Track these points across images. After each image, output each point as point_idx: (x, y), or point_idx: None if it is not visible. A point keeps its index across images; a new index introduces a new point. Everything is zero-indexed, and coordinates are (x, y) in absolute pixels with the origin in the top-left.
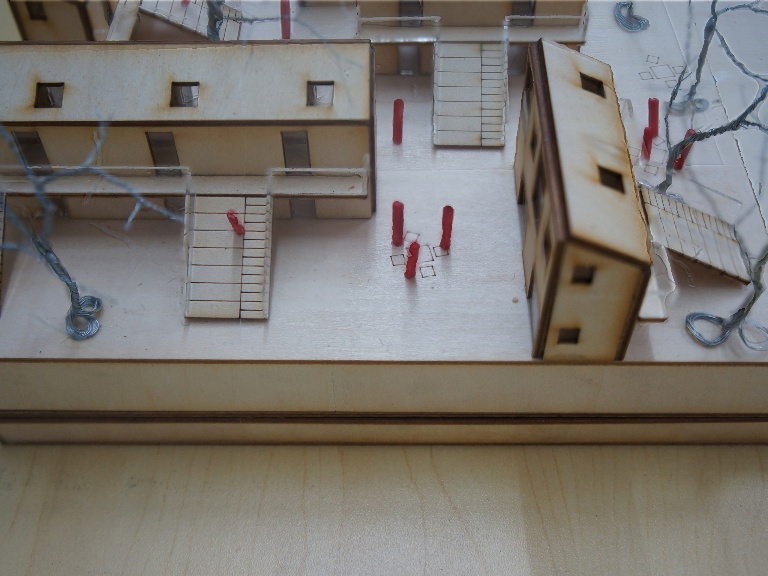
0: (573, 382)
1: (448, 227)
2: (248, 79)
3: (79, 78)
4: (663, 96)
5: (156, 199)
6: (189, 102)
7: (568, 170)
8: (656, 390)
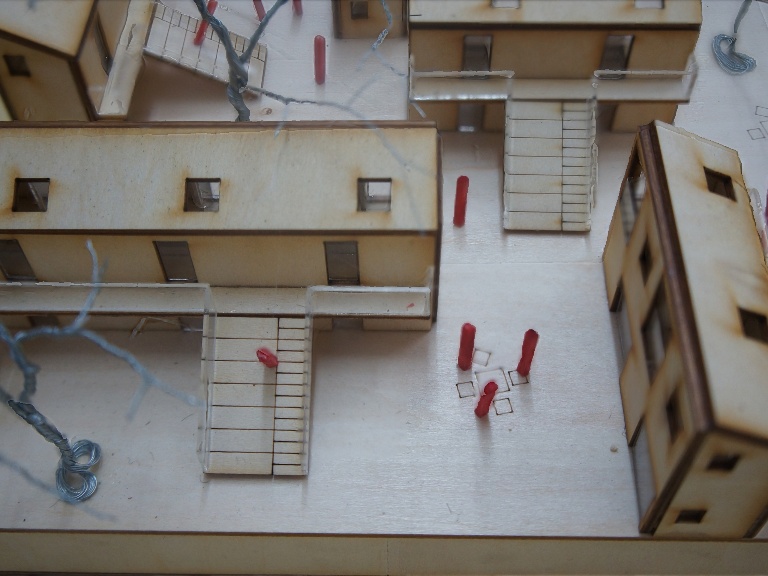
0: (686, 555)
1: (529, 353)
2: (282, 175)
3: (68, 172)
4: None
5: (167, 318)
6: (207, 200)
7: (704, 321)
8: None
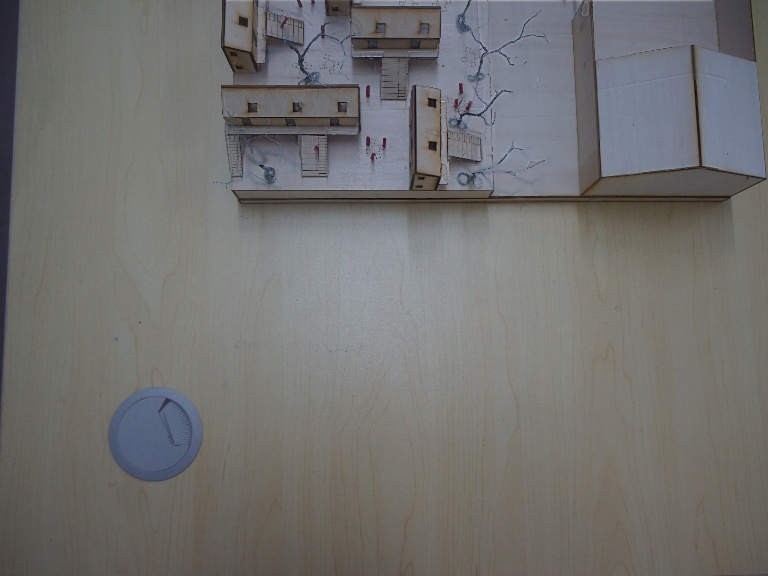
0: None
1: None
2: (318, 102)
3: (262, 101)
4: (468, 71)
5: None
6: (298, 106)
7: (419, 147)
8: None
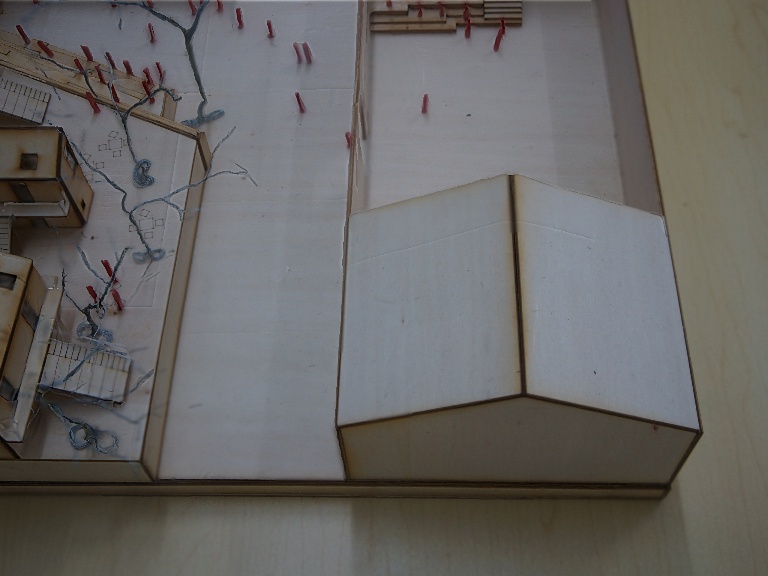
0: (2, 468)
1: None
2: None
3: None
4: (137, 247)
5: None
6: None
7: None
8: (59, 471)
